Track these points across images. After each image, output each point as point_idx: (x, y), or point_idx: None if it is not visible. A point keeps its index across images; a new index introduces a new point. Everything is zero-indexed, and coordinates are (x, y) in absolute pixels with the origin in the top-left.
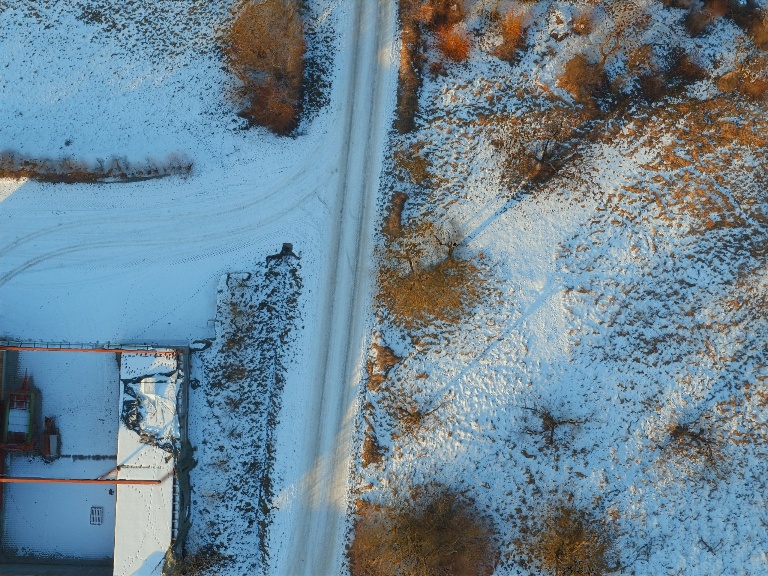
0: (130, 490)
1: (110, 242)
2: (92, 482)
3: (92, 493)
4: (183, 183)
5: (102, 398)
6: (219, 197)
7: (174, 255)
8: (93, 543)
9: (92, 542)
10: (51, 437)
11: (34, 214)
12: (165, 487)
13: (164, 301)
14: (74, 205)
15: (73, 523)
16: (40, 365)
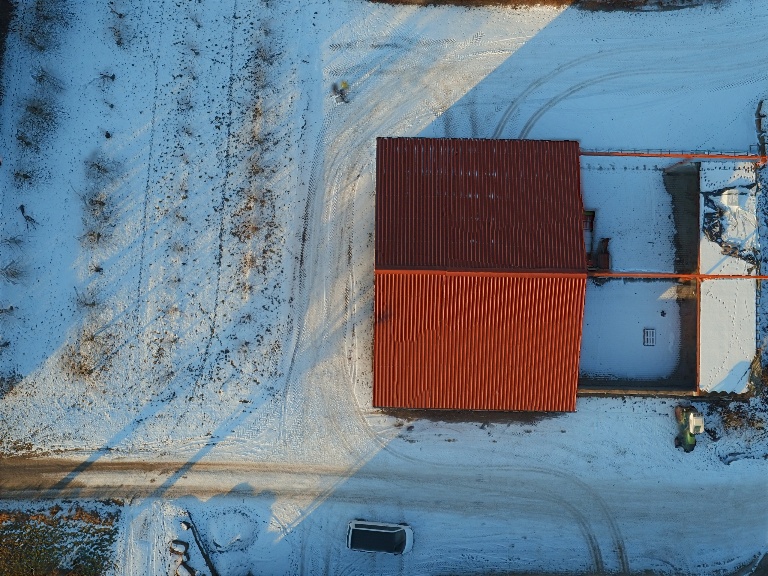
0: (714, 301)
1: (649, 69)
2: (727, 277)
3: (644, 315)
4: (714, 13)
5: (651, 221)
6: (748, 27)
7: (711, 83)
8: (646, 365)
9: (645, 364)
10: (610, 257)
11: (574, 41)
12: (748, 298)
13: (705, 127)
14: (612, 33)
15: (625, 345)
16: (588, 189)
